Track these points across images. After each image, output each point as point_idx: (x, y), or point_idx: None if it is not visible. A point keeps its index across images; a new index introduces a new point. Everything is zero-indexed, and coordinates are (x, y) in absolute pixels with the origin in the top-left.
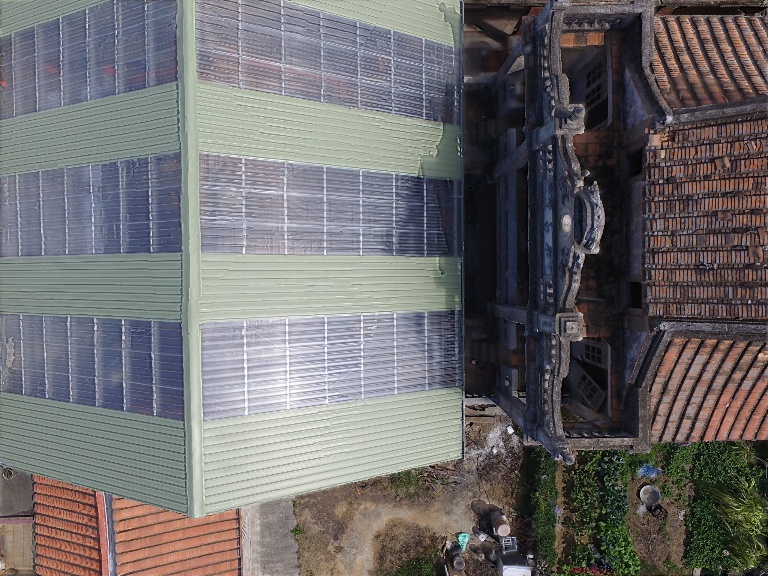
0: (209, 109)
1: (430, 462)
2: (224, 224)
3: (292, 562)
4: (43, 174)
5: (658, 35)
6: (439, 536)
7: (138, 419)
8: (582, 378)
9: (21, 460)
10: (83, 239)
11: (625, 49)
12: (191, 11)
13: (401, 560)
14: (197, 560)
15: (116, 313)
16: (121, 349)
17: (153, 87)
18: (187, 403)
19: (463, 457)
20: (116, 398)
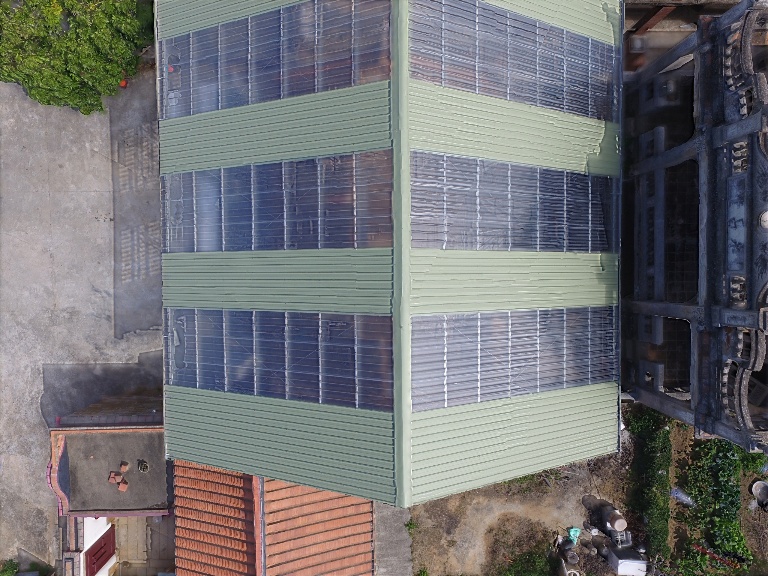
0: (418, 107)
1: (592, 455)
2: (428, 220)
3: (406, 556)
4: (225, 171)
5: None
6: (550, 531)
7: (336, 411)
8: (732, 373)
9: (193, 452)
10: (273, 235)
11: None
12: (406, 11)
13: (514, 554)
14: (335, 552)
15: (312, 307)
16: (317, 343)
17: (360, 86)
18: (398, 395)
19: (619, 451)
20: (310, 391)
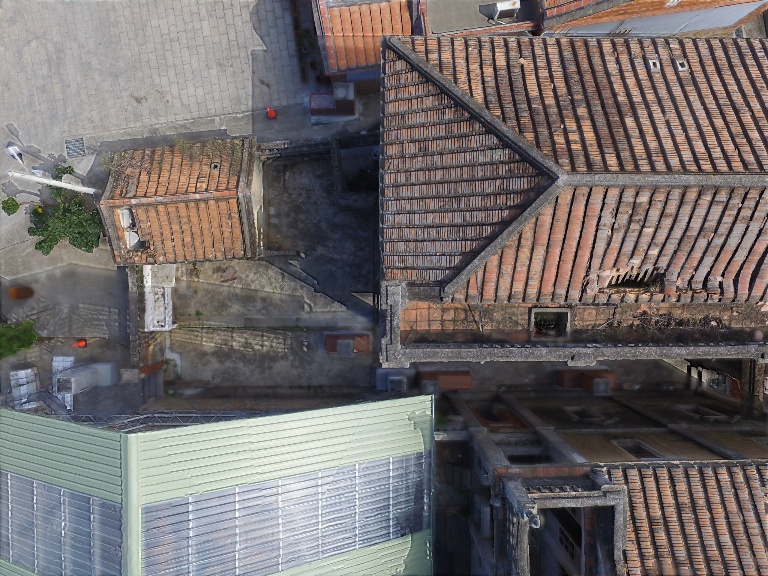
0: None
1: None
2: None
3: None
4: None
5: (633, 499)
6: None
7: None
8: None
9: None
10: None
11: (598, 519)
12: (136, 546)
13: None
14: None
15: None
16: None
17: None
18: None
19: None
20: None
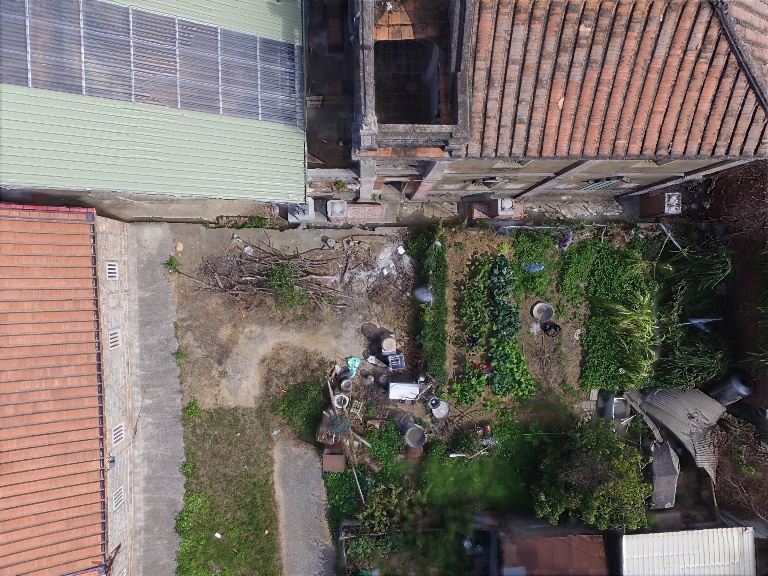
0: None
1: (265, 198)
2: None
3: (174, 387)
4: None
5: None
6: (328, 361)
7: None
8: None
9: None
10: None
11: None
12: None
13: (288, 384)
14: (49, 348)
15: None
16: None
17: None
18: None
19: (305, 201)
20: None
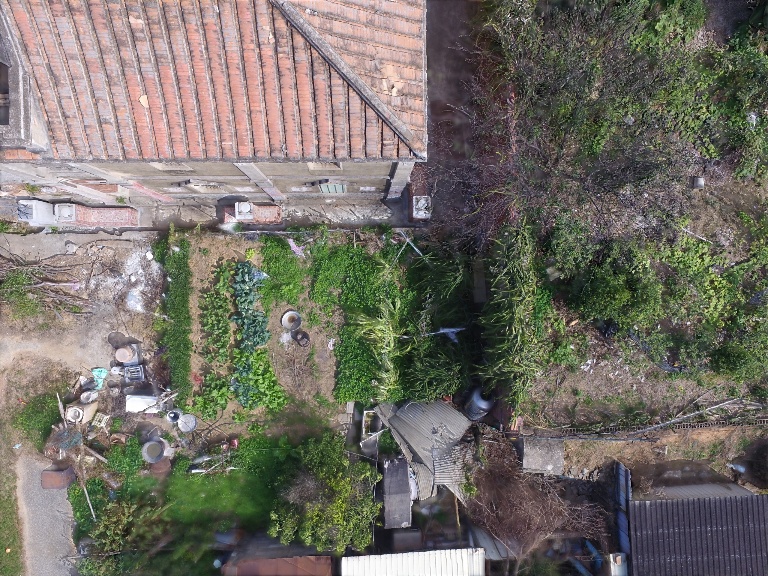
0: None
1: None
2: None
3: None
4: None
5: None
6: (73, 371)
7: None
8: None
9: None
10: None
11: None
12: None
13: (28, 396)
14: None
15: None
16: None
17: None
18: None
19: None
20: None
